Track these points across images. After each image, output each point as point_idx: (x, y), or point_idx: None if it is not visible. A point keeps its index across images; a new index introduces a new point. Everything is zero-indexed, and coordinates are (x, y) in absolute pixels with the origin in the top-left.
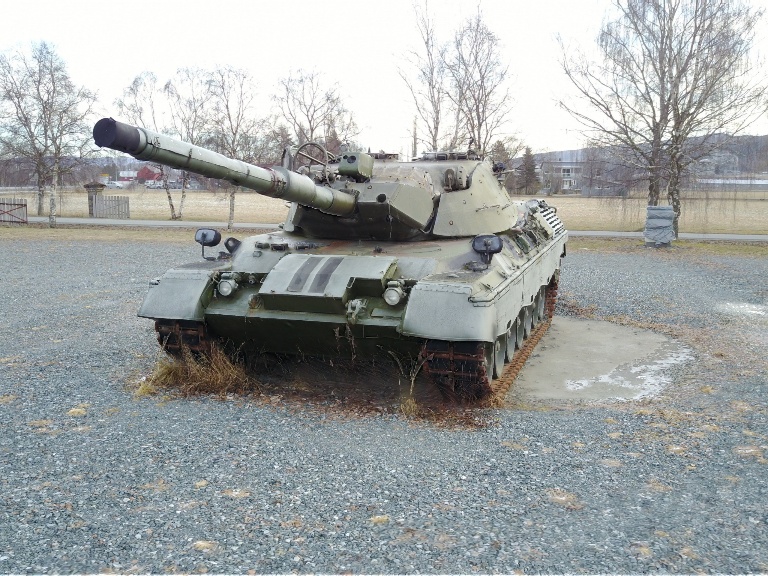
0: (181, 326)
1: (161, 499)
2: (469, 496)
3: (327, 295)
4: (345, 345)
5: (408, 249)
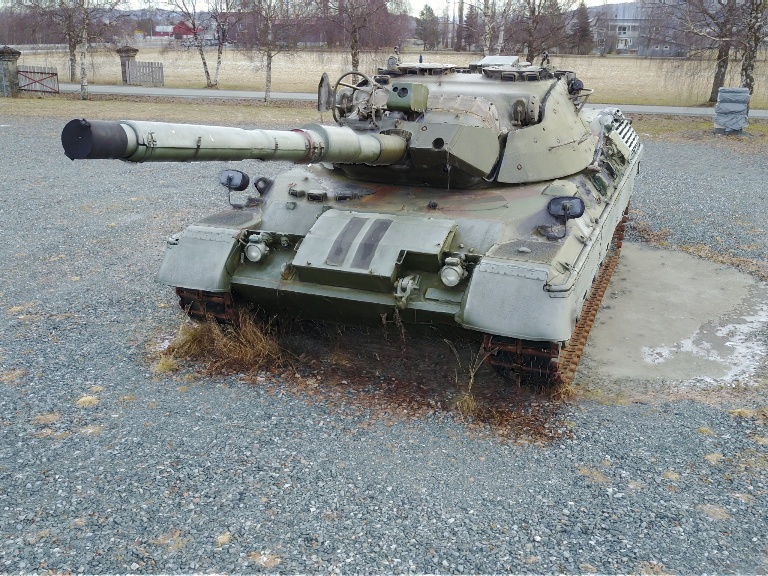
0: (205, 292)
1: (175, 567)
2: (546, 574)
3: (373, 273)
4: (393, 322)
5: (468, 204)
